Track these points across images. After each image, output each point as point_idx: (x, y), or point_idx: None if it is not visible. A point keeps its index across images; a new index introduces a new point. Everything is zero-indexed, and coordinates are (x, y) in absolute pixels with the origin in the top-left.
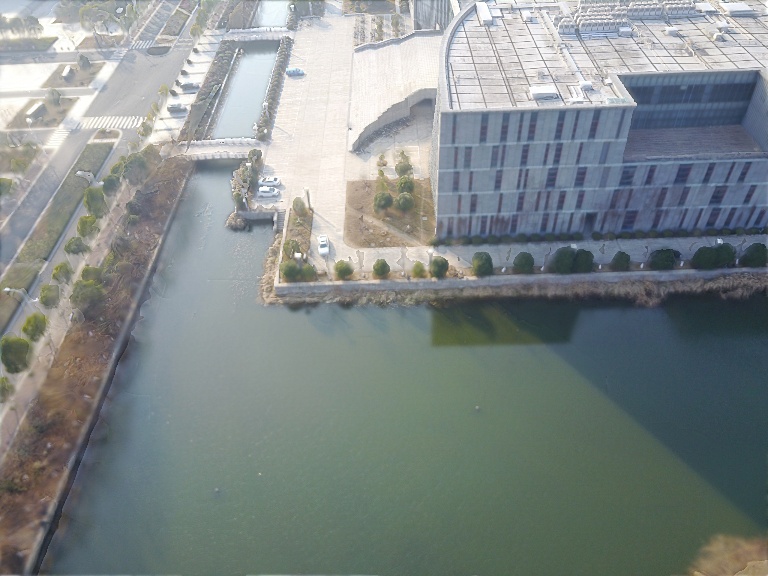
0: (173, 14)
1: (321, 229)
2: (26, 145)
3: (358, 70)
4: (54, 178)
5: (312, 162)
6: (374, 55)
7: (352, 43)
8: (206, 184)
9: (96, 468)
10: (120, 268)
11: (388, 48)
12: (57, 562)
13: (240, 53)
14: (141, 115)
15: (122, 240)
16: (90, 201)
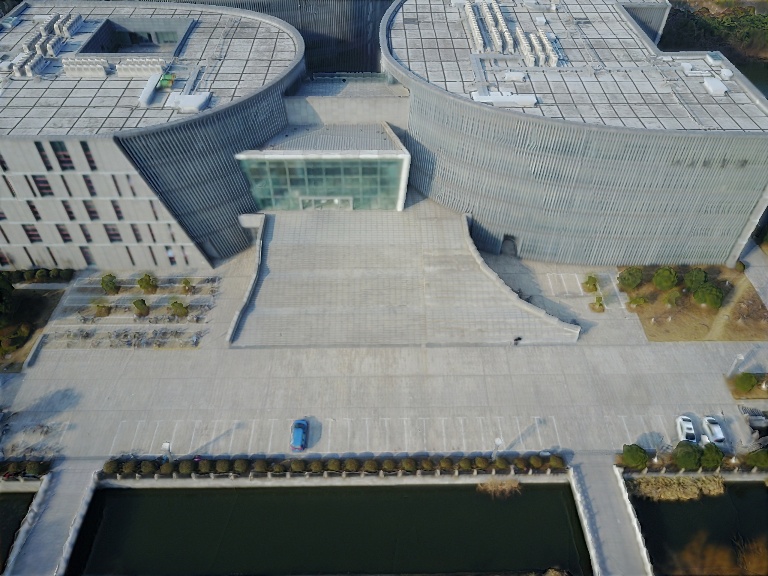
0: None
1: (763, 363)
2: None
3: (316, 335)
4: None
5: (613, 384)
6: (277, 309)
7: (182, 350)
8: (693, 550)
9: None
10: None
11: (272, 286)
12: None
13: None
14: None
15: None
16: None
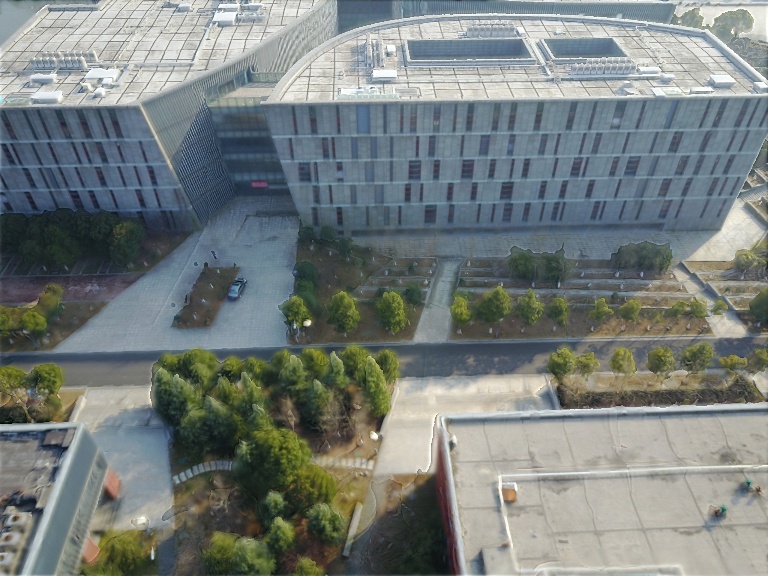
0: None
1: None
2: None
3: None
4: None
5: None
6: None
7: None
8: None
9: (73, 2)
10: None
11: None
12: (42, 4)
13: None
14: None
15: None
16: None
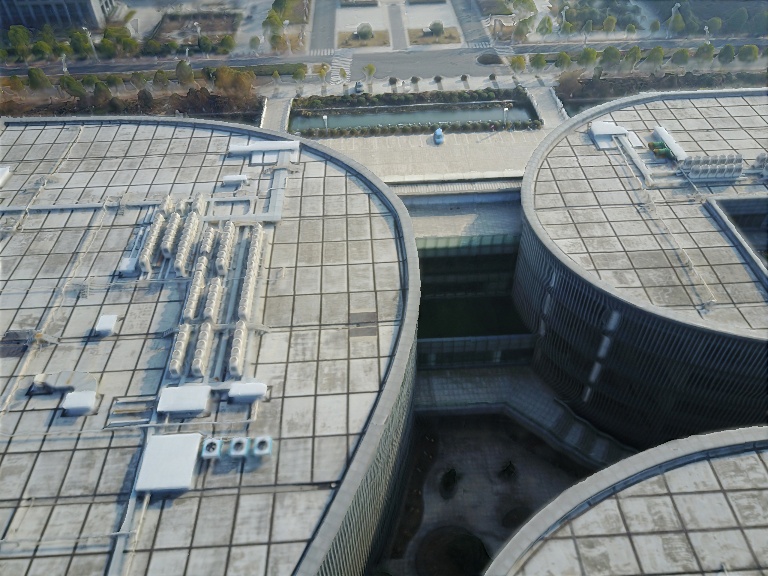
0: None
1: None
2: (274, 35)
3: None
4: None
5: None
6: None
7: None
8: None
9: None
10: (111, 99)
11: None
12: None
13: (505, 104)
14: (353, 76)
15: (141, 94)
16: (177, 68)
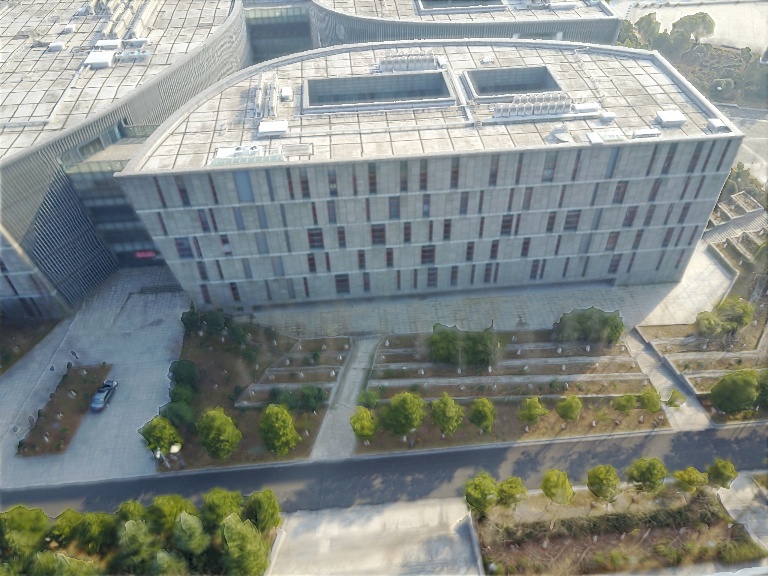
0: None
1: None
2: None
3: None
4: None
5: None
6: None
7: None
8: None
9: None
10: None
11: None
12: None
13: None
14: None
15: None
16: None
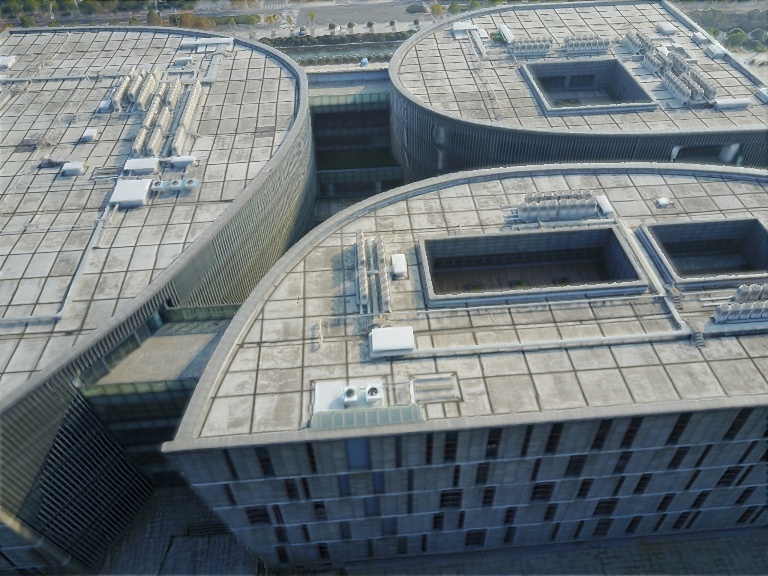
0: (504, 3)
1: None
2: None
3: None
4: (219, 15)
5: None
6: None
7: None
8: None
9: None
10: None
11: None
12: None
13: None
14: (299, 23)
15: None
16: None
